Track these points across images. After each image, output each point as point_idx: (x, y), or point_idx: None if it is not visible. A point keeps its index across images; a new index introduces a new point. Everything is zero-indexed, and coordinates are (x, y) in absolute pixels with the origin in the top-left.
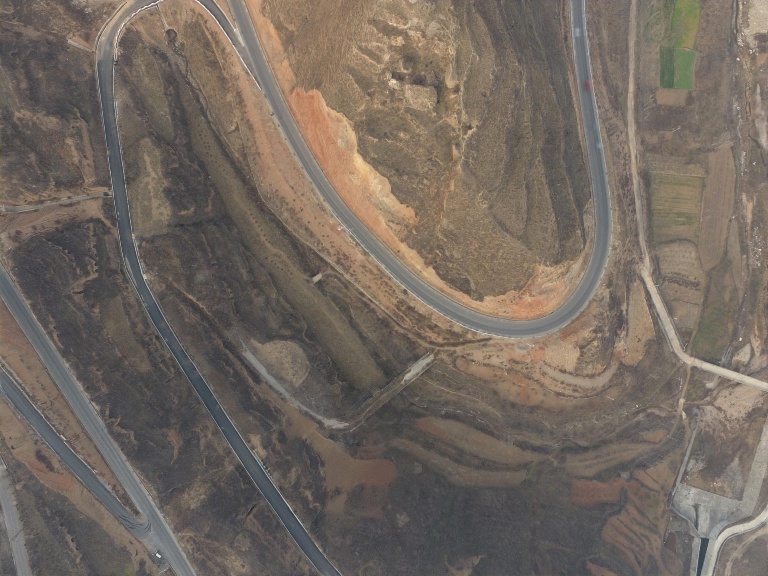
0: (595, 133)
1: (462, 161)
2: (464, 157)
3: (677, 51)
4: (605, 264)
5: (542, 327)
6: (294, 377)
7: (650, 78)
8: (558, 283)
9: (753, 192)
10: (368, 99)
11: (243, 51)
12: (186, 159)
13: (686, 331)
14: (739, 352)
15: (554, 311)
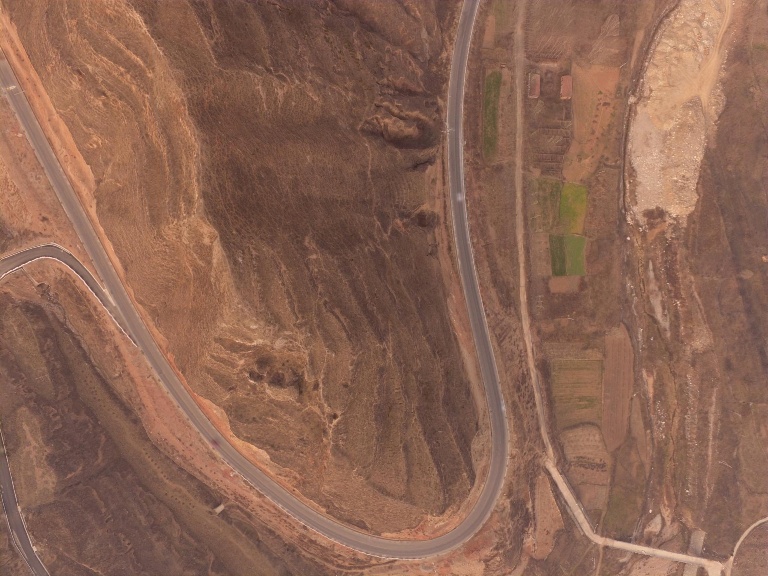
0: (485, 343)
1: (331, 446)
2: (333, 442)
3: (567, 238)
4: (504, 474)
5: (446, 544)
6: None
7: (541, 268)
8: (451, 519)
9: (653, 367)
10: (231, 391)
11: (115, 311)
12: (71, 413)
13: (595, 513)
14: (650, 523)
15: (457, 526)
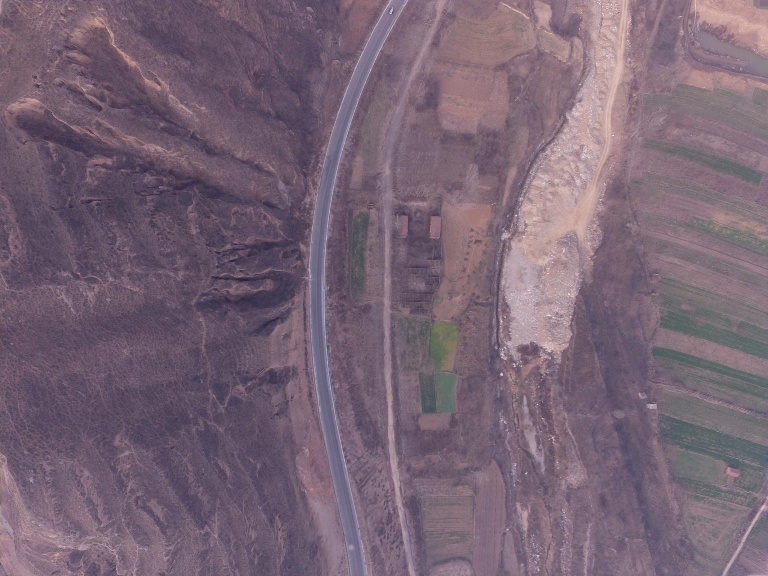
0: (345, 489)
1: None
2: None
3: (437, 375)
4: None
5: None
6: None
7: (411, 405)
8: None
9: (527, 501)
10: (55, 574)
11: None
12: None
13: None
14: None
15: None
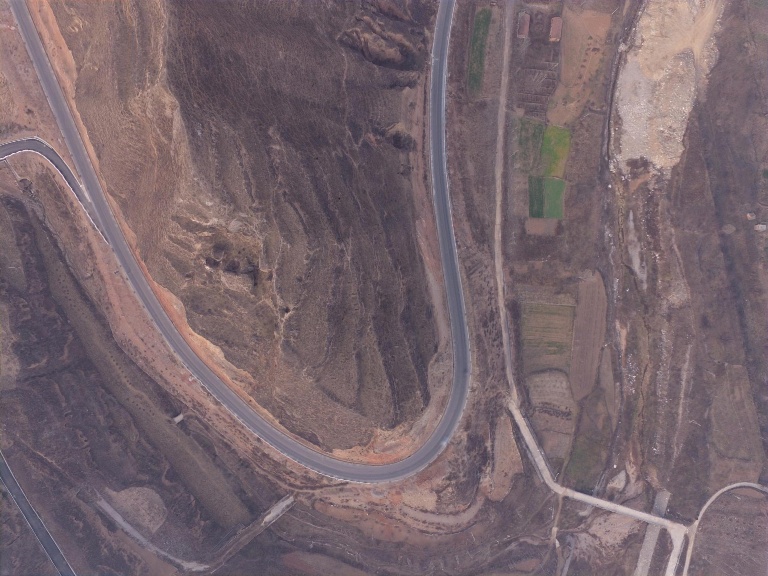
0: (454, 273)
1: (282, 341)
2: (284, 337)
3: (546, 180)
4: (463, 406)
5: (399, 471)
6: (151, 523)
7: (519, 208)
8: (402, 439)
9: (627, 319)
10: (188, 279)
11: (89, 206)
12: (41, 307)
13: (557, 461)
14: (614, 479)
15: (411, 455)
